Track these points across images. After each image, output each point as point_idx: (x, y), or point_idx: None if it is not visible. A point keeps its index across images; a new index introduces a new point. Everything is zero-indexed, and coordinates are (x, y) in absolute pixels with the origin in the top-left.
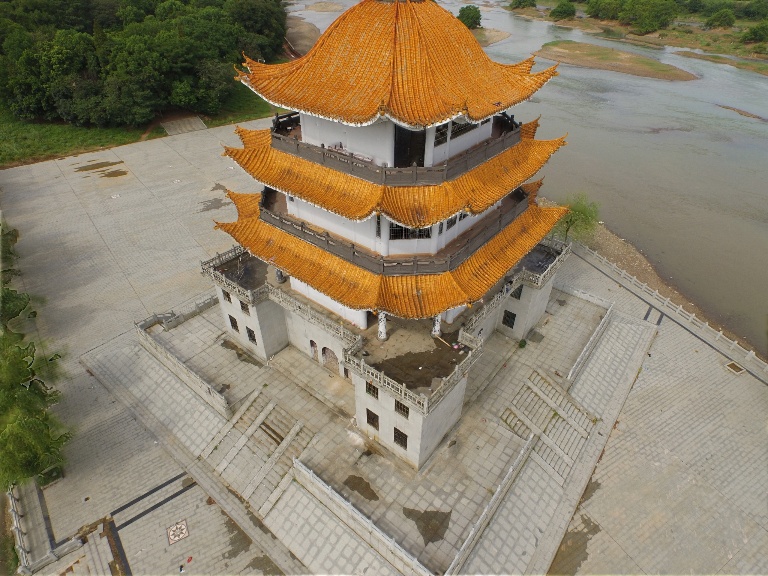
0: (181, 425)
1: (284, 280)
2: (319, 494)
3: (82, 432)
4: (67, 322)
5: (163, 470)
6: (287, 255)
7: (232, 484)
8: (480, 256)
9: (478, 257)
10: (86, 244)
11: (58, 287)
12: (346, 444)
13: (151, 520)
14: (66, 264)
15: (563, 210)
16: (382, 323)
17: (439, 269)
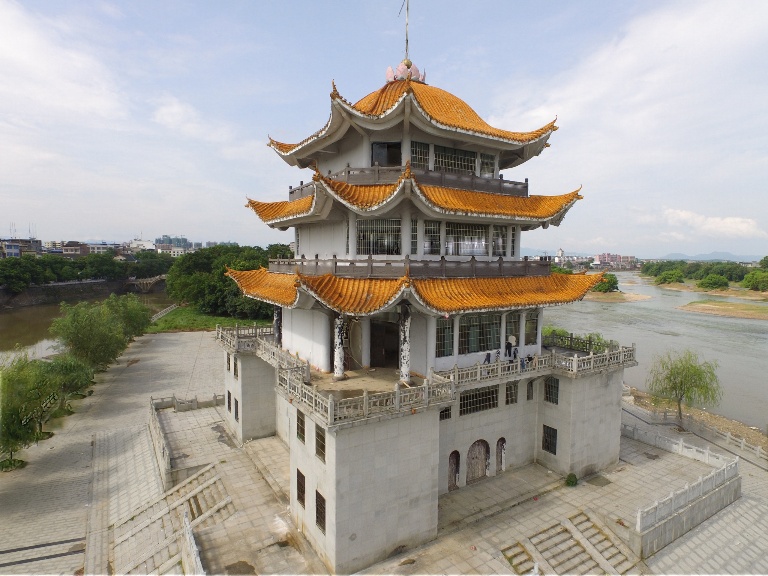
0: (122, 493)
1: (281, 345)
2: (189, 575)
3: (37, 482)
4: (113, 410)
5: (67, 530)
6: (271, 289)
7: (117, 559)
8: (463, 286)
9: (460, 286)
10: (178, 371)
11: (131, 391)
12: (264, 528)
13: (6, 573)
14: (152, 380)
15: (596, 277)
16: (337, 352)
17: (397, 274)
